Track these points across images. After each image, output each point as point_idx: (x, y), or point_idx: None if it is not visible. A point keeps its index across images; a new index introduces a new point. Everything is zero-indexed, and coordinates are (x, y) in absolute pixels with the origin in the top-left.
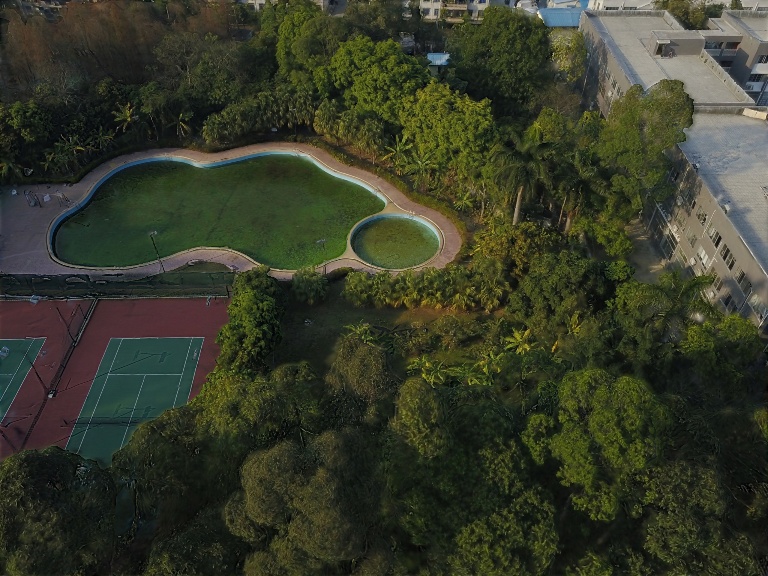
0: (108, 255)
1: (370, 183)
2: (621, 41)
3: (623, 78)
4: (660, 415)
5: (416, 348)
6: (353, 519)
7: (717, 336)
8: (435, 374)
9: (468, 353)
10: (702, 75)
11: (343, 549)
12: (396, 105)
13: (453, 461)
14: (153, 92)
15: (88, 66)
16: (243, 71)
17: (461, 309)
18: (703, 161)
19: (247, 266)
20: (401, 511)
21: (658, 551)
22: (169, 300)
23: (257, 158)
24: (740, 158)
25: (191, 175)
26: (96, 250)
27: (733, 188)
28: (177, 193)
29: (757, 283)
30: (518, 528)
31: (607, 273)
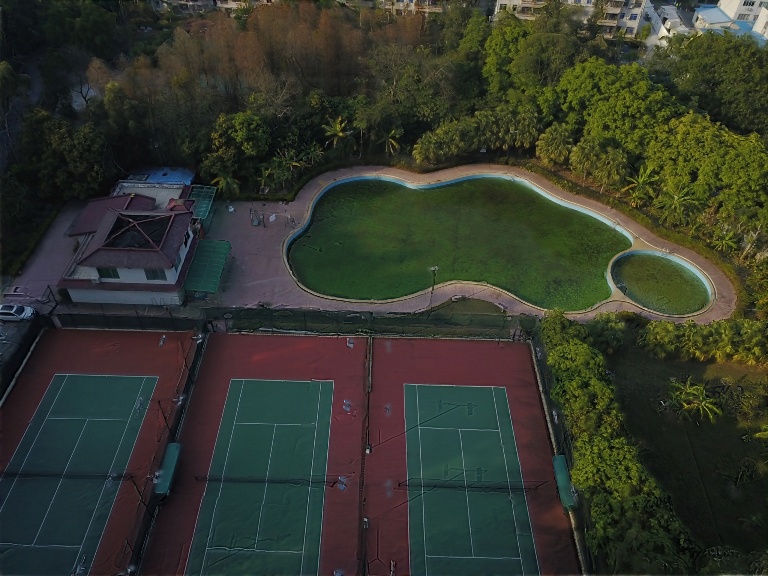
0: (356, 285)
1: (605, 215)
2: None
3: None
4: None
5: (752, 411)
6: None
7: None
8: None
9: None
10: None
11: None
12: (649, 134)
13: None
14: (365, 106)
15: None
16: None
17: None
18: None
19: (515, 305)
20: None
21: None
22: (448, 341)
23: (469, 181)
24: None
25: (407, 197)
26: (341, 279)
27: None
28: (400, 217)
29: None
30: None
31: None
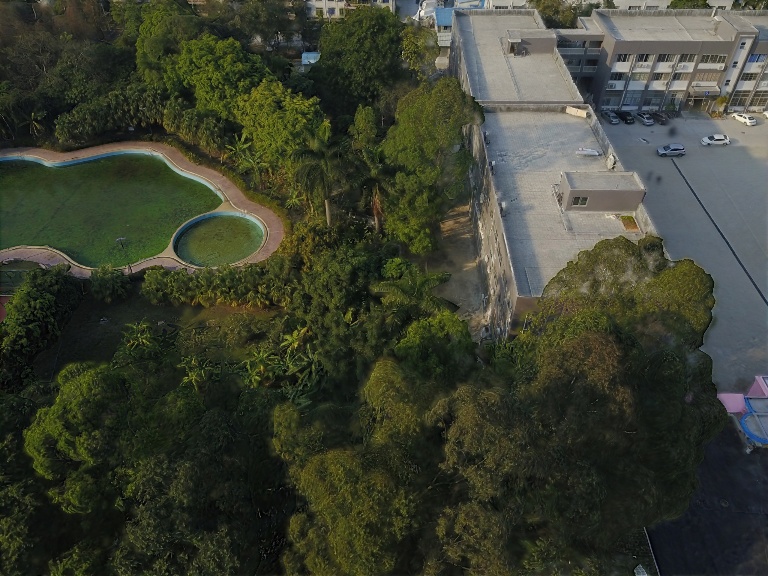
0: None
1: (213, 182)
2: (481, 40)
3: (465, 77)
4: (175, 408)
5: (196, 346)
6: None
7: (431, 332)
8: (198, 371)
9: (247, 351)
10: (548, 73)
11: None
12: (231, 104)
13: None
14: (4, 91)
15: None
16: (101, 70)
17: (257, 307)
18: (507, 159)
19: None
20: None
21: None
22: None
23: (110, 157)
24: (545, 156)
25: (39, 174)
26: None
27: (525, 185)
28: (19, 192)
29: (509, 280)
30: None
31: (383, 270)
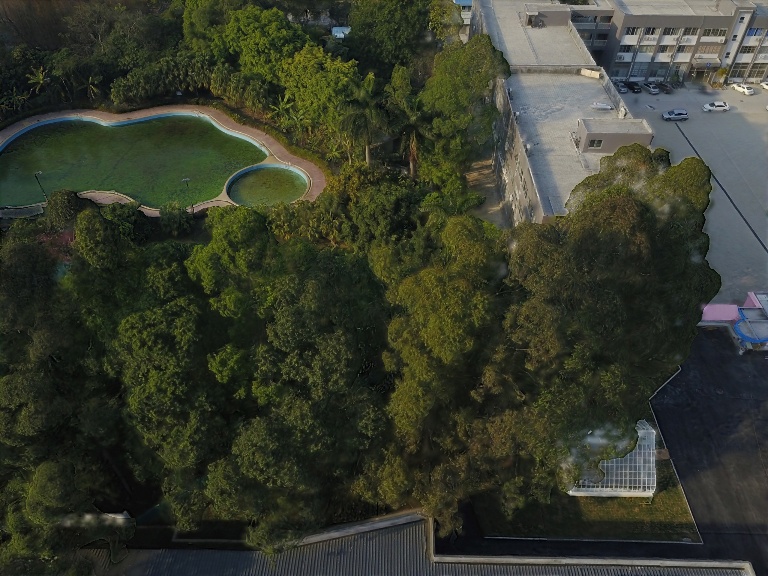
0: (7, 198)
1: (257, 139)
2: (501, 14)
3: None
4: (297, 248)
5: None
6: (19, 299)
7: None
8: None
9: None
10: (563, 43)
11: (5, 316)
12: (276, 66)
13: (127, 276)
14: (65, 57)
15: (6, 34)
16: (151, 40)
17: None
18: (529, 112)
19: None
20: (88, 315)
21: (274, 341)
22: None
23: (161, 118)
24: (563, 109)
25: (97, 132)
26: None
27: (546, 133)
28: (81, 147)
29: (535, 205)
30: (162, 319)
31: (422, 203)
